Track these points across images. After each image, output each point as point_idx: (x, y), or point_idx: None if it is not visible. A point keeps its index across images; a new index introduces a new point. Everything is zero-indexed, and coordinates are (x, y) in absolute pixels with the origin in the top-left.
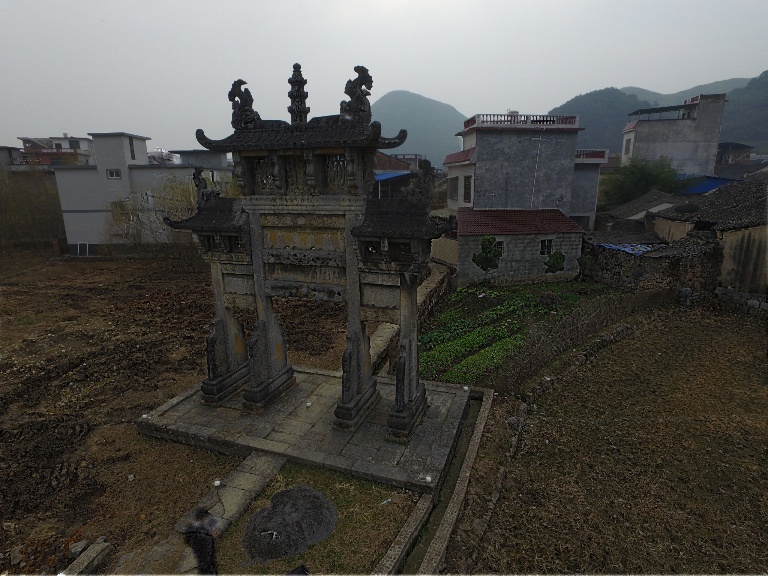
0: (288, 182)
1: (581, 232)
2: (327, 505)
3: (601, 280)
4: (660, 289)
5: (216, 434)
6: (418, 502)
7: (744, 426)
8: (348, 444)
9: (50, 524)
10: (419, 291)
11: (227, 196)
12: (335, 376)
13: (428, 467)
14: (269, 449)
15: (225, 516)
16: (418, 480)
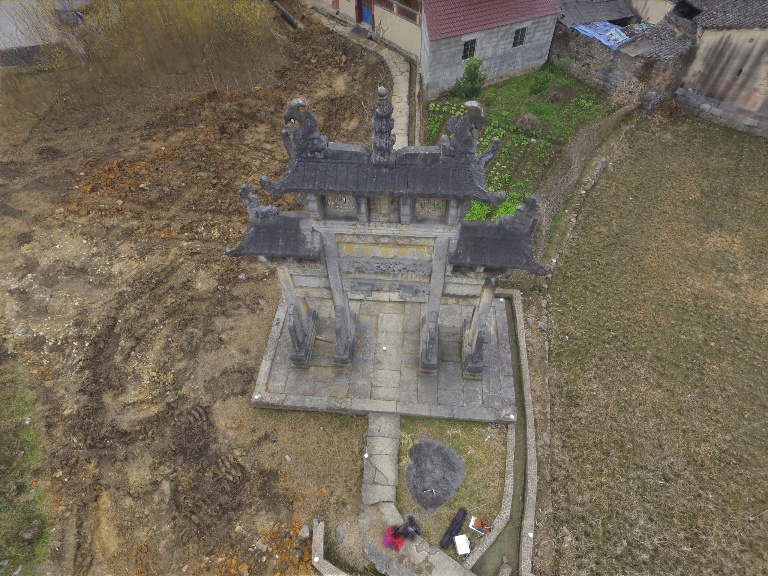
0: (370, 209)
1: (557, 13)
2: (450, 452)
3: (568, 69)
4: (633, 106)
5: (331, 403)
6: (508, 433)
7: (695, 290)
8: (438, 390)
9: (264, 517)
10: (396, 123)
11: (117, 6)
12: (385, 301)
13: (506, 402)
14: (383, 411)
15: (390, 483)
16: (504, 417)
